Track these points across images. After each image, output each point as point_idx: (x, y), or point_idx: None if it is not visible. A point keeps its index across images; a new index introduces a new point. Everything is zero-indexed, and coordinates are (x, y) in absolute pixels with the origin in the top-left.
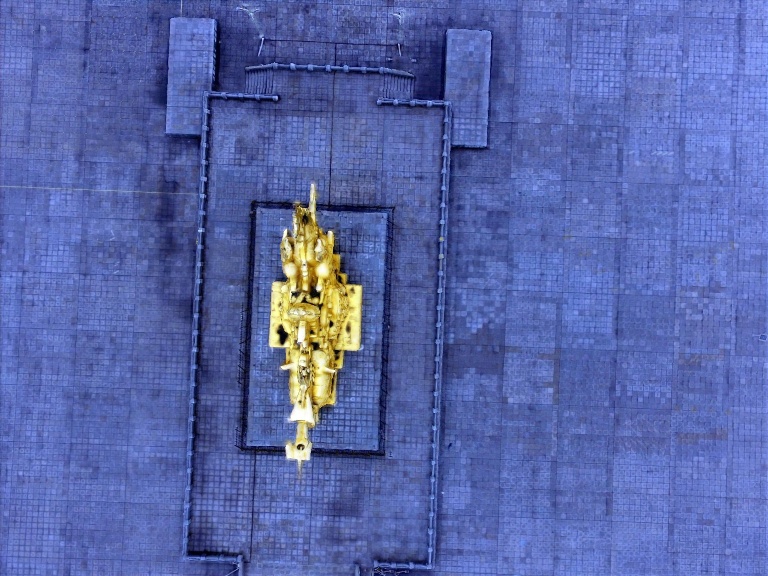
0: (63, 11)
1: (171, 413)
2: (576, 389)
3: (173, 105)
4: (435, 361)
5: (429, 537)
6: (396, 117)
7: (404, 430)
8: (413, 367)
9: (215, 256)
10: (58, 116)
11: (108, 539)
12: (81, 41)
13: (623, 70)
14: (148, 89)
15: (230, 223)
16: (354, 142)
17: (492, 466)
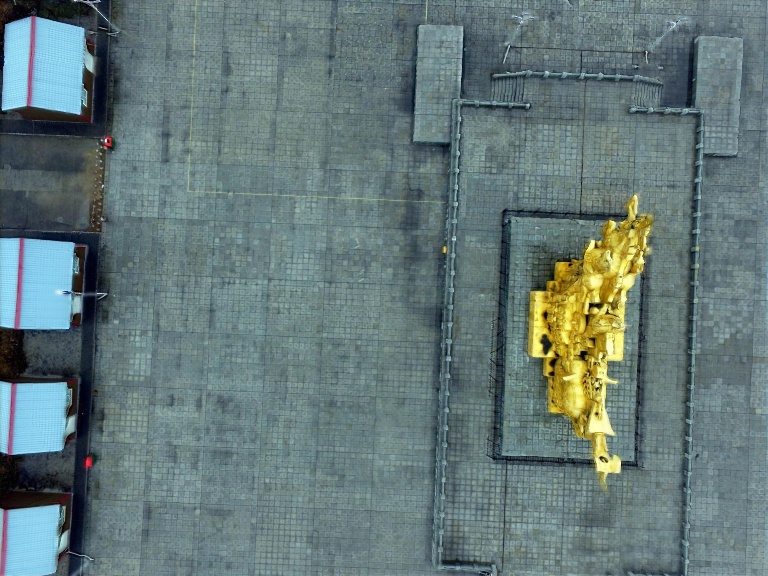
0: (308, 18)
1: (416, 422)
2: None
3: (422, 113)
4: (690, 372)
5: (685, 549)
6: (648, 125)
7: (656, 441)
8: (665, 377)
9: (465, 265)
10: (303, 124)
11: (354, 547)
12: (326, 48)
13: None
14: (393, 97)
15: (481, 232)
16: (606, 150)
17: (740, 477)
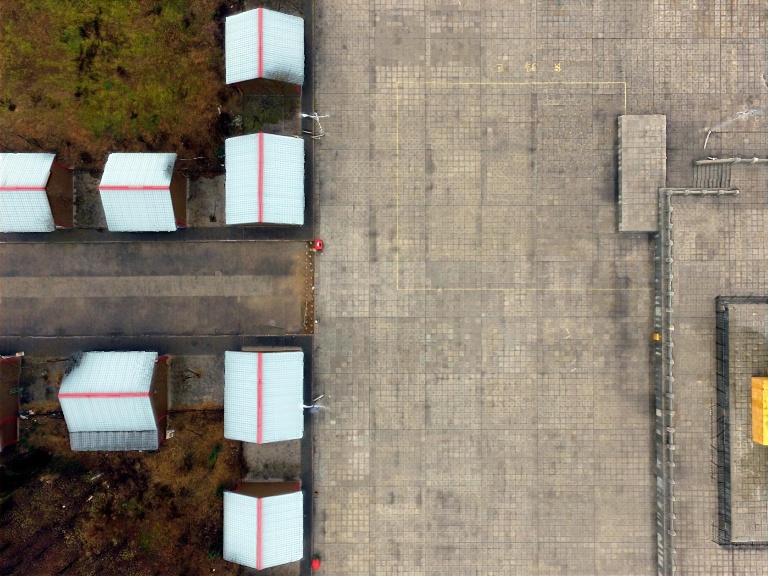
0: (509, 113)
1: (636, 508)
2: None
3: (628, 202)
4: None
5: None
6: None
7: None
8: None
9: (681, 352)
10: (509, 217)
11: None
12: (528, 142)
13: None
14: (596, 186)
15: (695, 319)
16: None
17: None
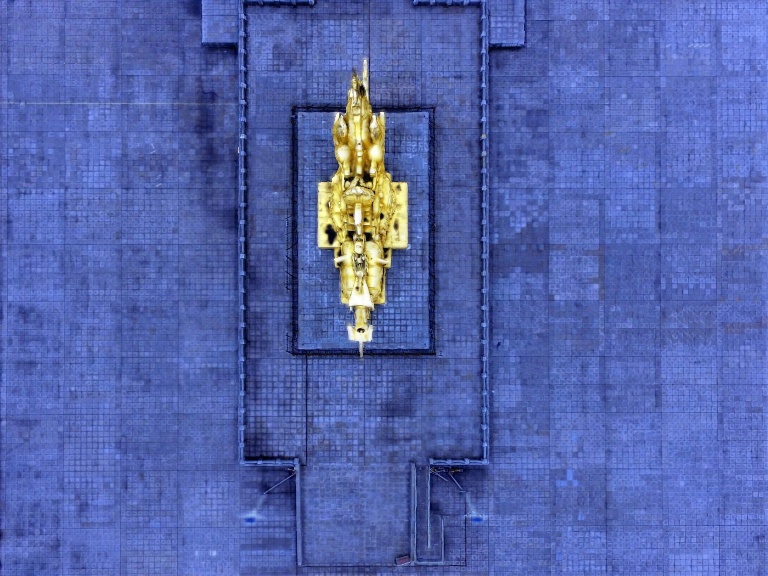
0: None
1: (220, 323)
2: (621, 284)
3: (208, 14)
4: (482, 258)
5: (483, 432)
6: (433, 17)
7: (453, 329)
8: (460, 266)
9: (258, 163)
10: (93, 30)
11: (163, 450)
12: None
13: None
14: None
15: (271, 130)
16: (392, 44)
17: (541, 363)
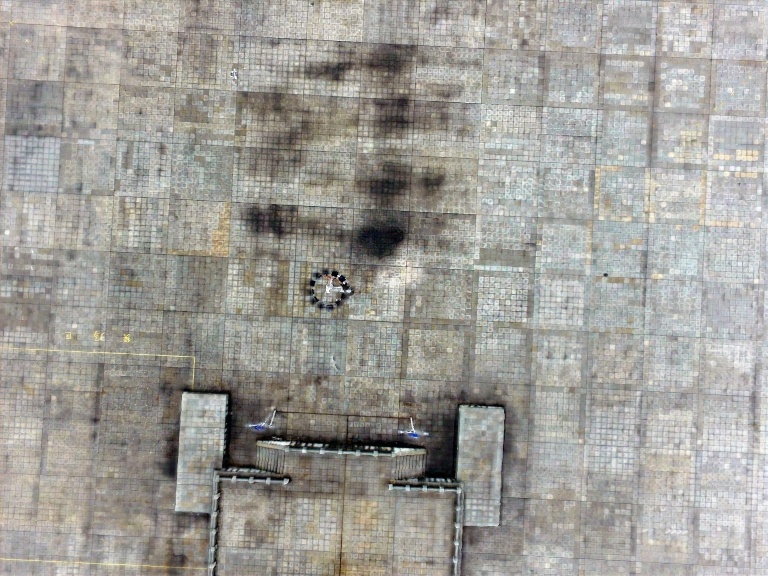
0: (74, 381)
1: None
2: None
3: (183, 483)
4: None
5: None
6: (408, 500)
7: None
8: None
9: None
10: (67, 488)
11: None
12: (92, 412)
13: (637, 447)
14: (158, 460)
15: None
16: (365, 525)
17: None
